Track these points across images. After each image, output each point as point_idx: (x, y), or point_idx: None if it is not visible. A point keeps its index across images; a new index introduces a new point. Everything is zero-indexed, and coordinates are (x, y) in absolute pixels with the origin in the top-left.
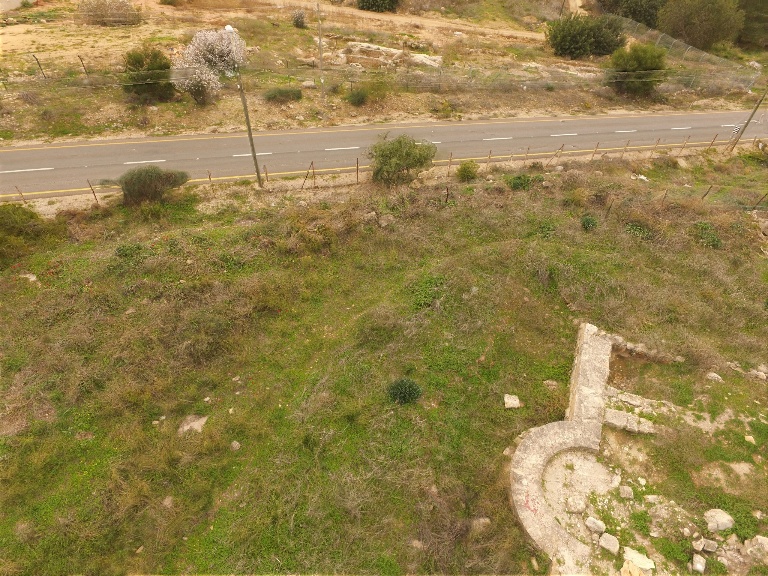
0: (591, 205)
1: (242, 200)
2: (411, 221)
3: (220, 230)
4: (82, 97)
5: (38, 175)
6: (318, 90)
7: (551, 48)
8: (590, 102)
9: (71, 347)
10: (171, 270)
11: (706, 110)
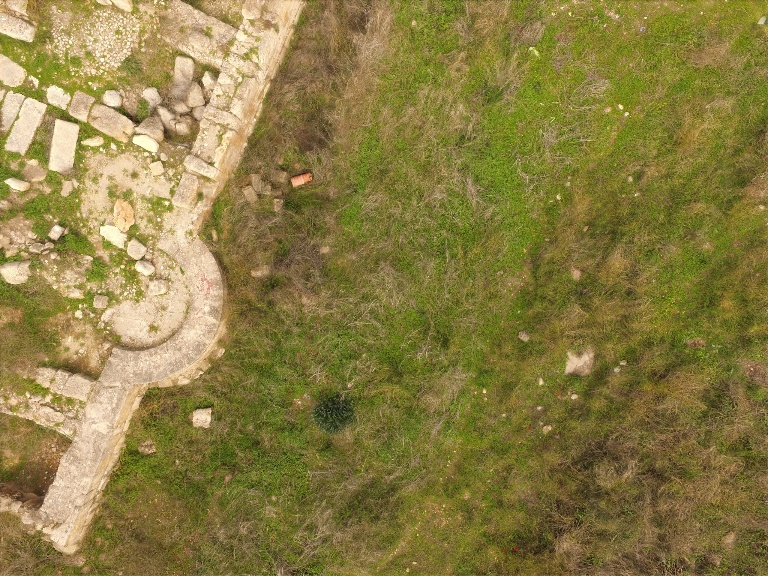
0: None
1: None
2: None
3: None
4: None
5: None
6: None
7: None
8: None
9: None
10: None
11: None
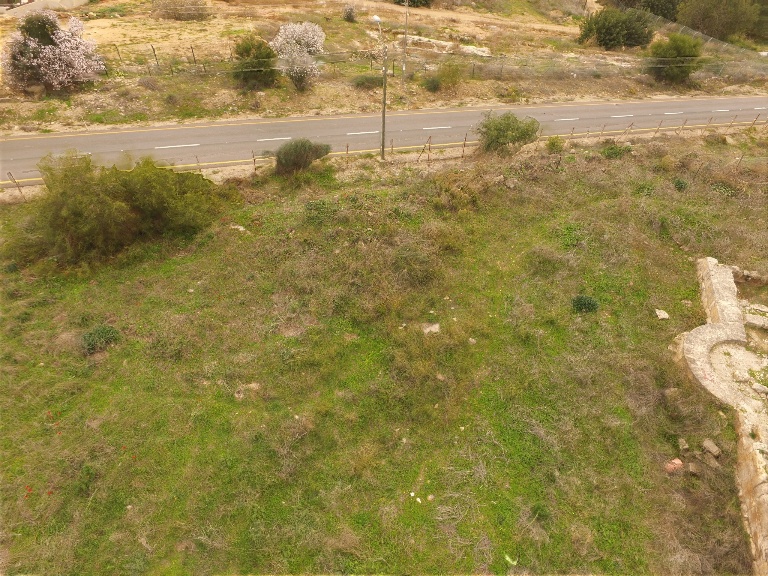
0: (679, 169)
1: (370, 170)
2: (533, 183)
3: (378, 191)
4: (193, 84)
5: (190, 150)
6: (397, 77)
7: (596, 39)
8: (634, 88)
9: (308, 276)
10: (358, 220)
11: (737, 95)
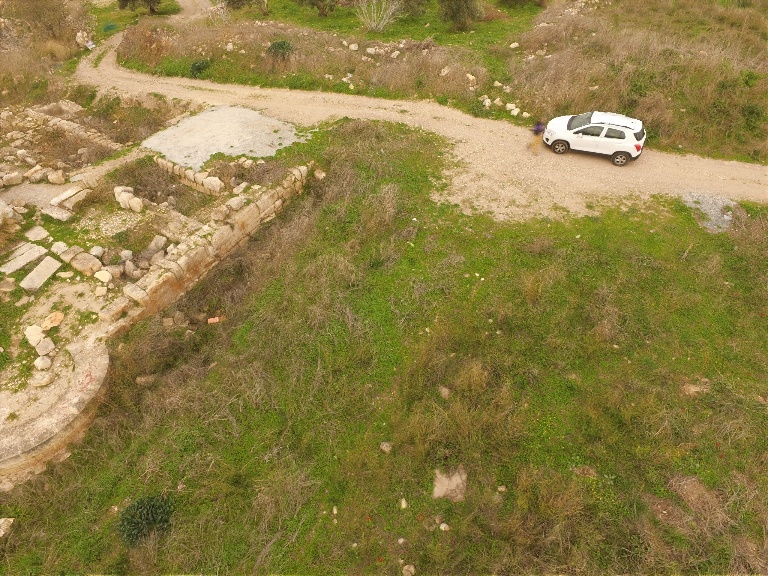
0: None
1: None
2: None
3: None
4: None
5: None
6: None
7: None
8: None
9: None
10: None
11: None
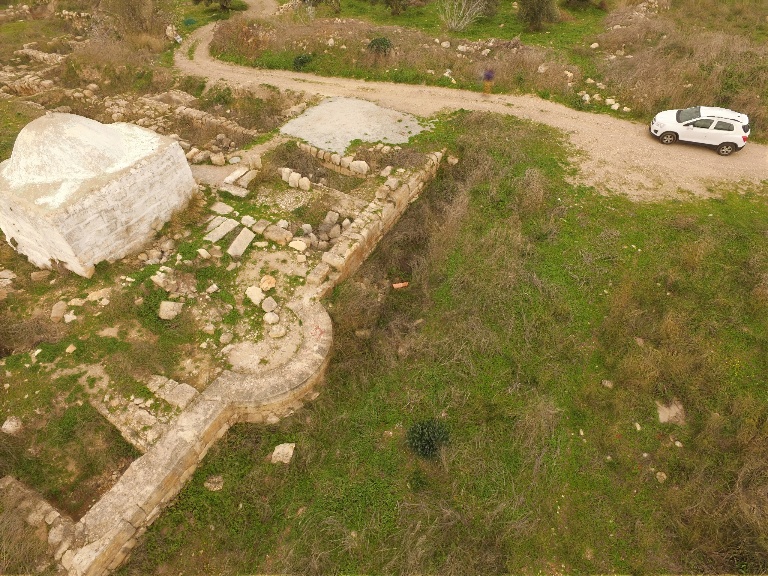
0: None
1: None
2: None
3: None
4: None
5: None
6: None
7: None
8: None
9: None
10: None
11: None
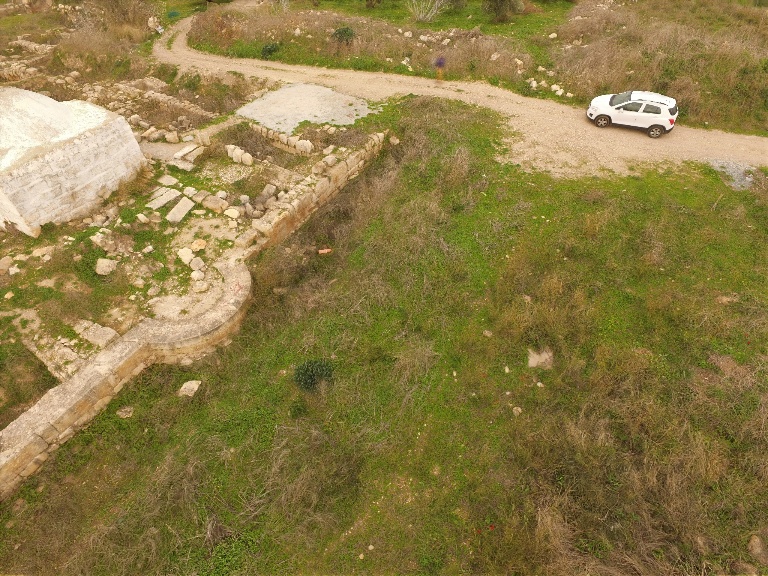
0: None
1: None
2: None
3: None
4: None
5: None
6: None
7: None
8: None
9: None
10: None
11: None
